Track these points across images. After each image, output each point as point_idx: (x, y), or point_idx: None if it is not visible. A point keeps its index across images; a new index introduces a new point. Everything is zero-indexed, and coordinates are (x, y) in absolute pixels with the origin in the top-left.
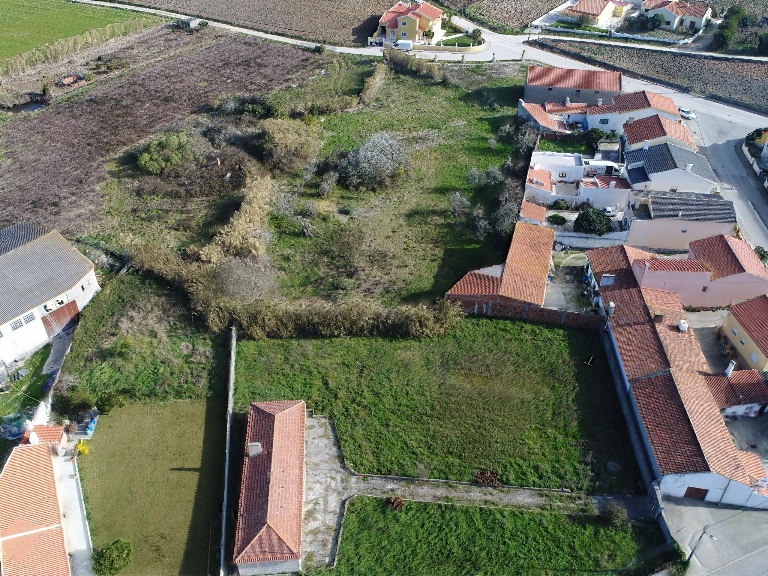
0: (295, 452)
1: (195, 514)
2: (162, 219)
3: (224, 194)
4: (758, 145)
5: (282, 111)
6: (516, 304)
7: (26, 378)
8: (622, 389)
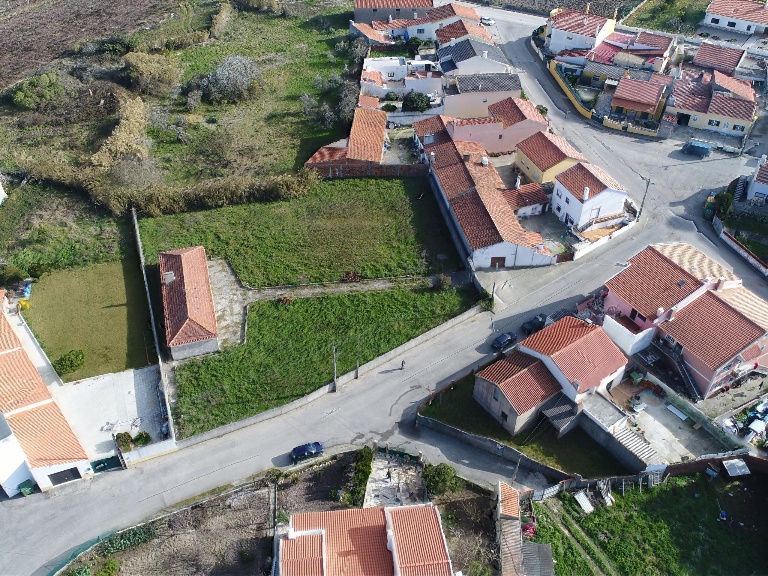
0: (202, 277)
1: (130, 331)
2: (48, 143)
3: (101, 118)
4: (542, 38)
5: (141, 47)
6: (361, 164)
7: None
8: (444, 209)
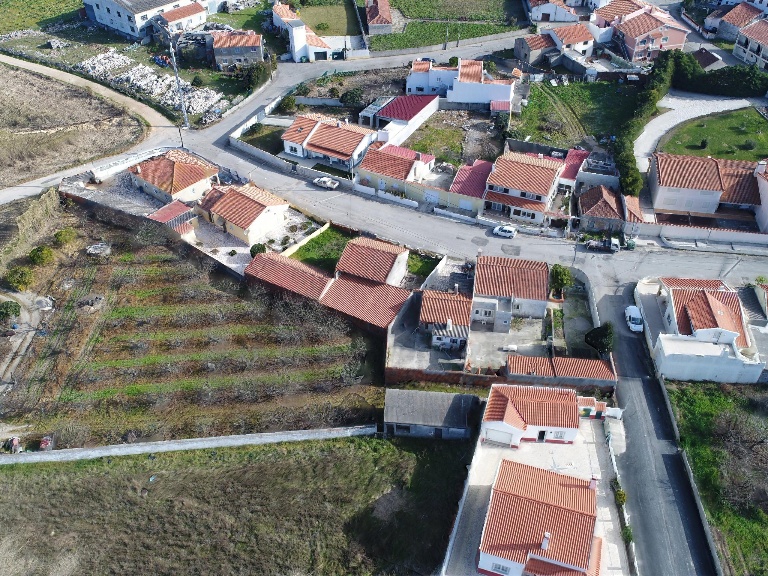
0: (386, 6)
1: (348, 25)
2: None
3: None
4: None
5: None
6: None
7: (262, 4)
8: None
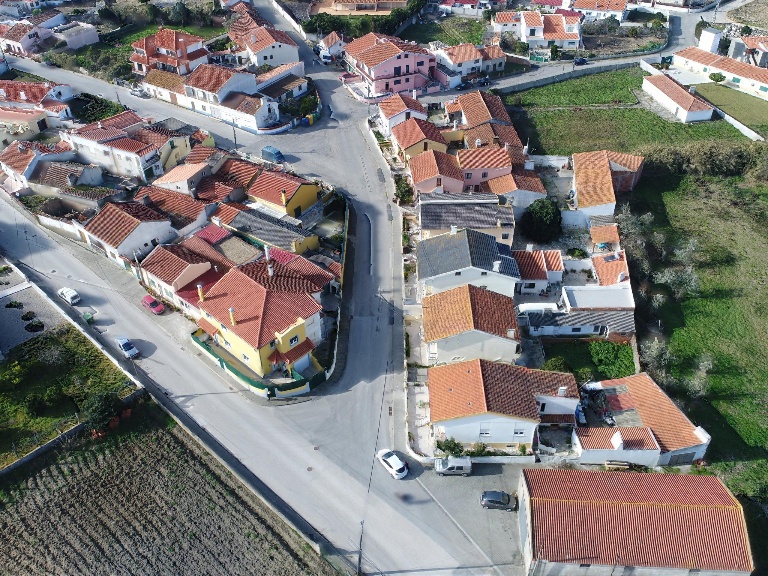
0: None
1: None
2: None
3: None
4: None
5: None
6: None
7: None
8: None
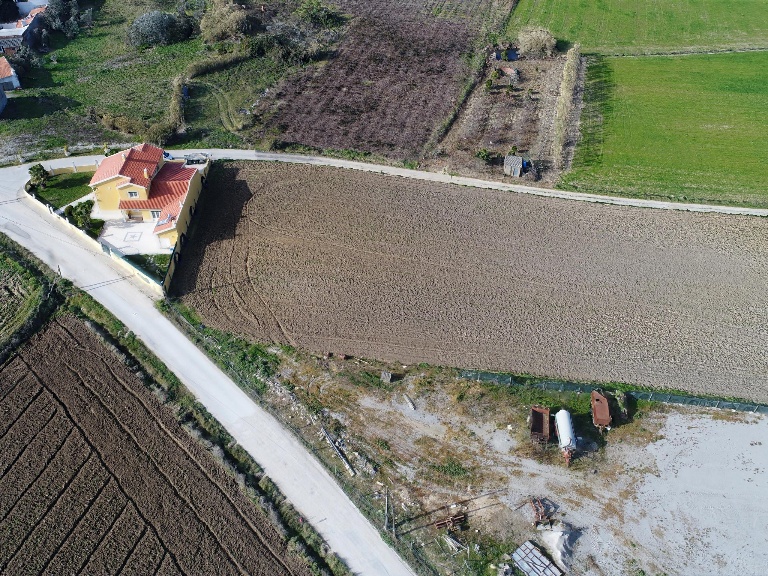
0: None
1: None
2: None
3: None
4: None
5: None
6: None
7: None
8: None
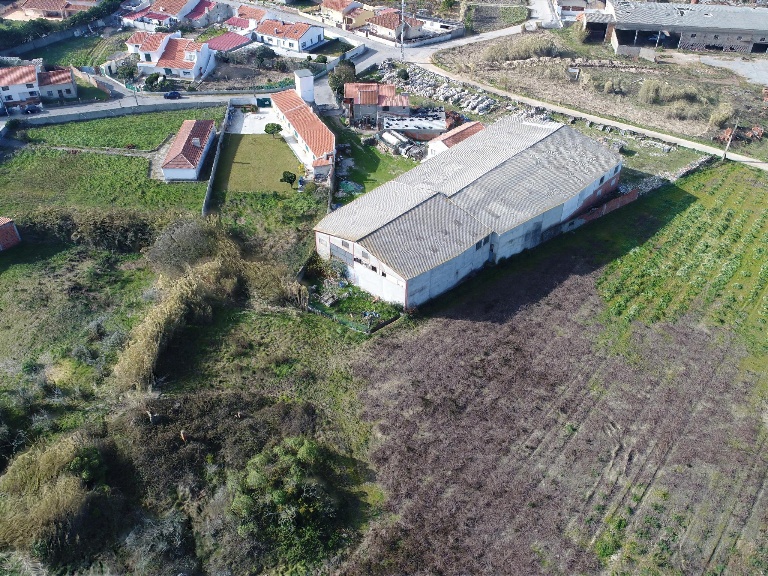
0: None
1: None
2: None
3: None
4: None
5: None
6: None
7: None
8: None
